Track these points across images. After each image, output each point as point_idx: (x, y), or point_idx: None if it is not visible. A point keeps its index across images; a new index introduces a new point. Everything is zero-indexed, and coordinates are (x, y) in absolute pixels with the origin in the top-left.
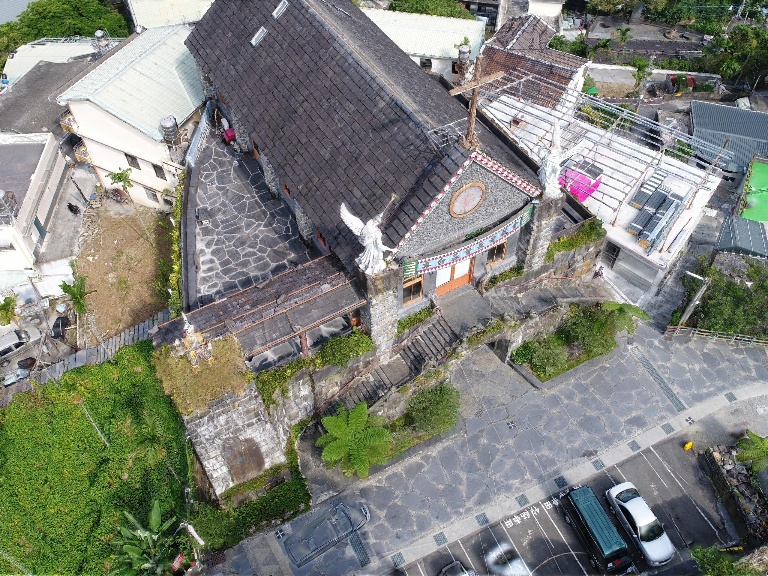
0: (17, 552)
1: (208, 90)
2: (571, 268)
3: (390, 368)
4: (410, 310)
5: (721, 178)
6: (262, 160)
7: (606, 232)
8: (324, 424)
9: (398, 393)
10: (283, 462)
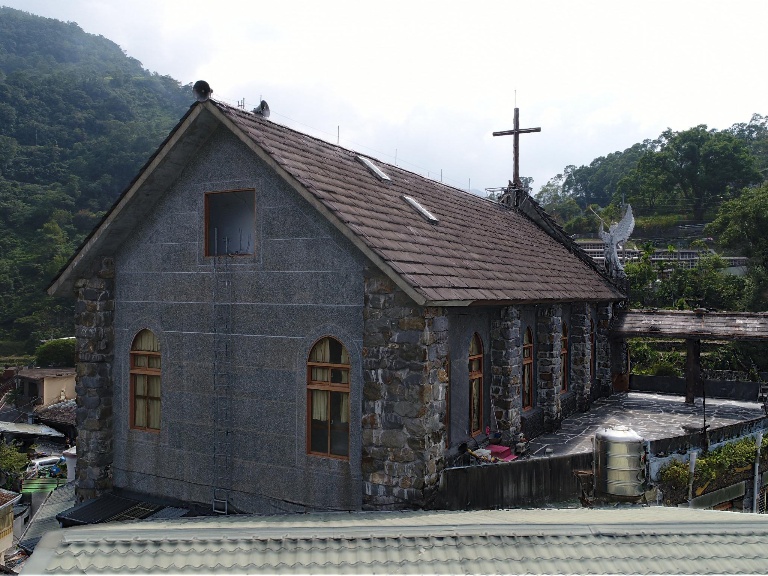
0: None
1: None
2: None
3: None
4: None
5: None
6: None
7: None
8: None
9: None
10: None
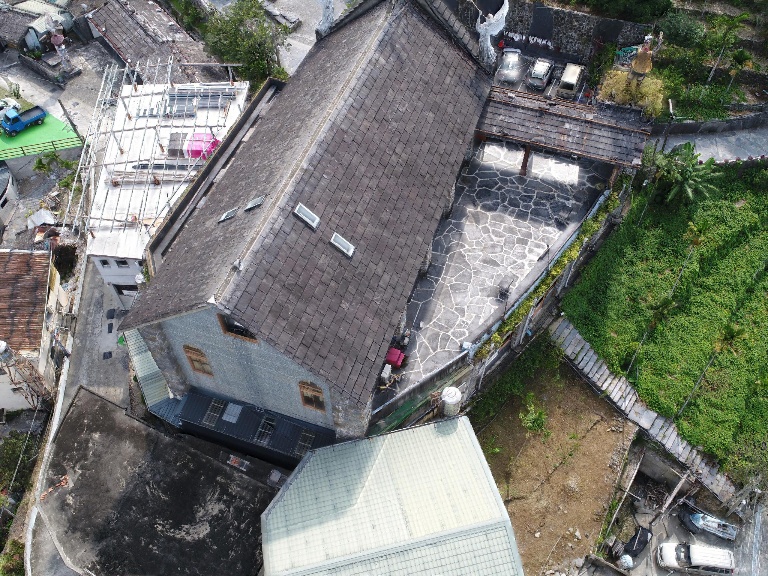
0: (759, 317)
1: None
2: None
3: None
4: None
5: (14, 188)
6: None
7: None
8: None
9: None
10: None
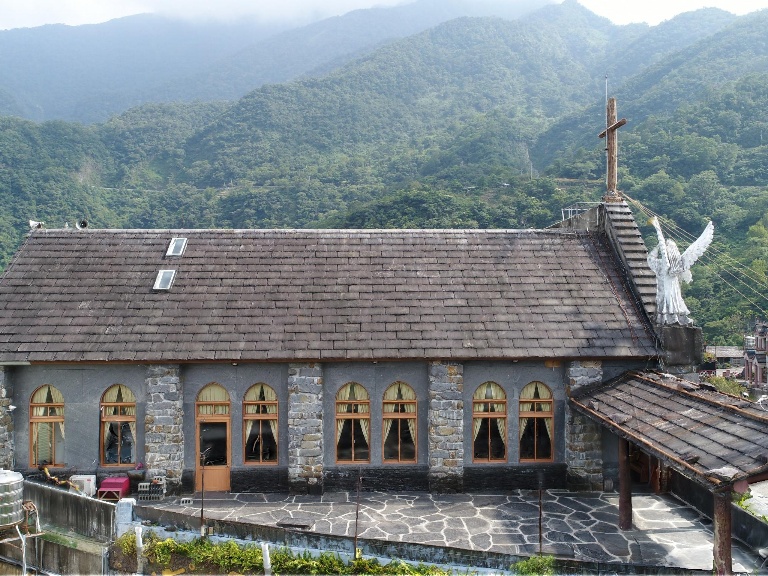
0: None
1: (4, 448)
2: None
3: None
4: None
5: None
6: (295, 419)
7: None
8: None
9: None
10: None
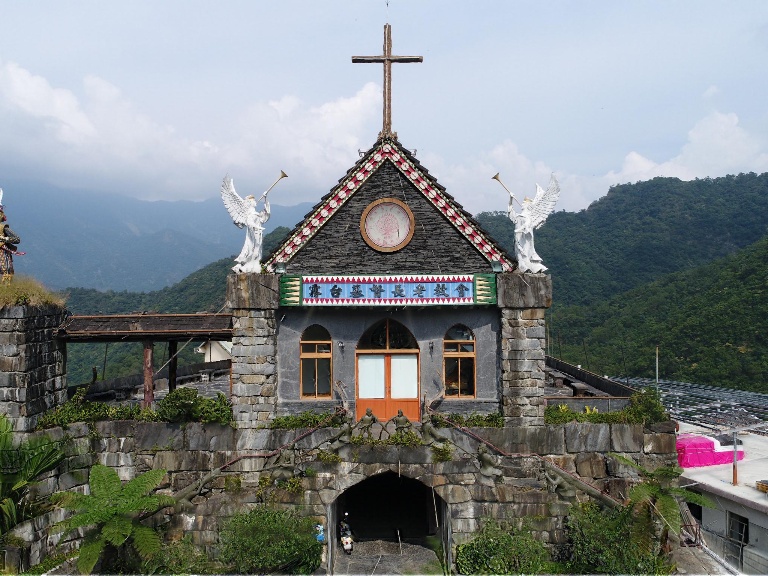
0: None
1: None
2: (615, 478)
3: (249, 484)
4: (308, 406)
5: None
6: None
7: (674, 422)
8: (93, 469)
9: (225, 493)
10: (26, 542)
